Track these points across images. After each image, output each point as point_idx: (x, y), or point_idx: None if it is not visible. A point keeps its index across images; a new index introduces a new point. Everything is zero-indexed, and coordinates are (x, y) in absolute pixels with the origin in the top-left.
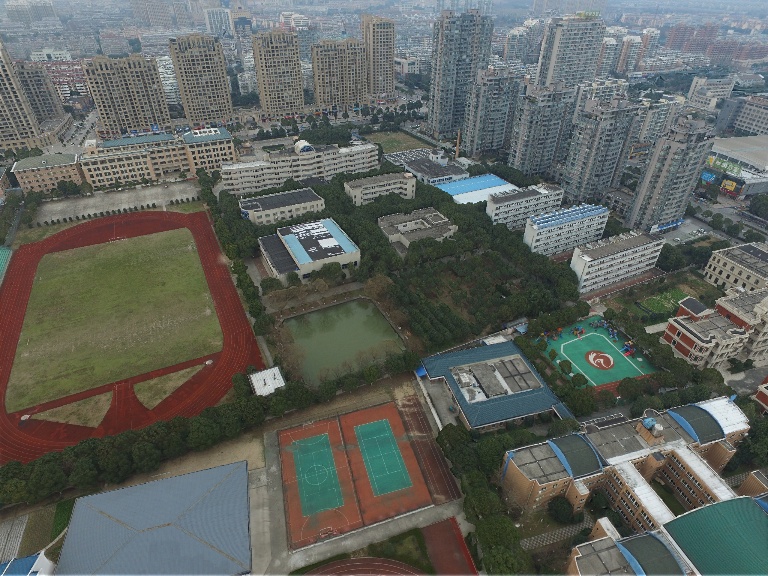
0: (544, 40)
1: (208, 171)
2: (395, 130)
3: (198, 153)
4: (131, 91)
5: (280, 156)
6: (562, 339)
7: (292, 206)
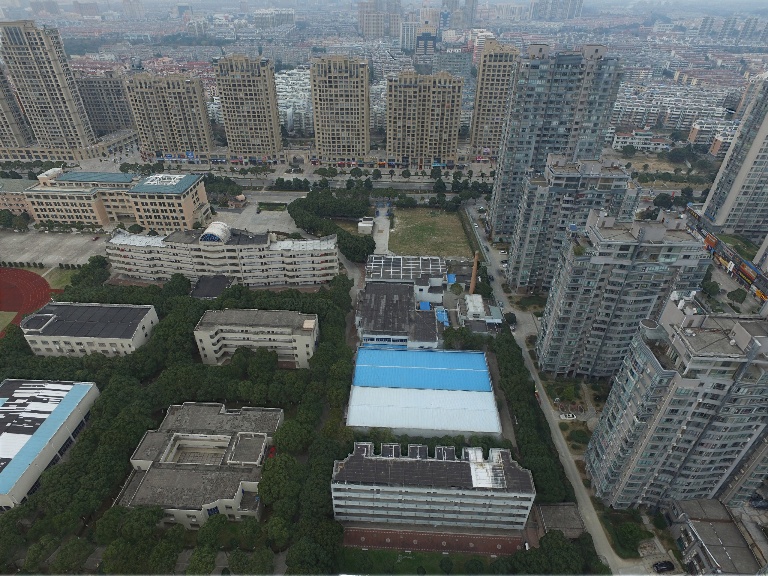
0: (750, 106)
1: (156, 227)
2: (451, 209)
3: (142, 205)
4: (170, 113)
5: (182, 238)
6: None
7: (81, 338)
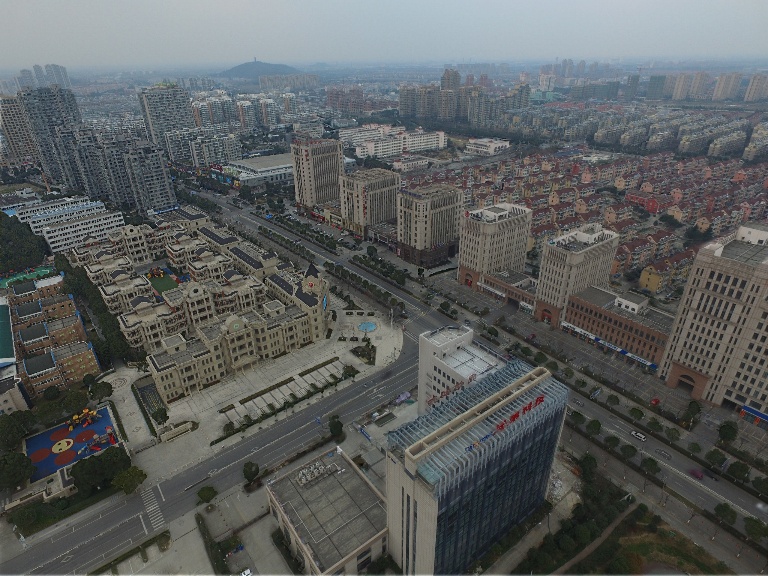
0: None
1: None
2: (20, 182)
3: None
4: None
5: None
6: (14, 277)
7: None
